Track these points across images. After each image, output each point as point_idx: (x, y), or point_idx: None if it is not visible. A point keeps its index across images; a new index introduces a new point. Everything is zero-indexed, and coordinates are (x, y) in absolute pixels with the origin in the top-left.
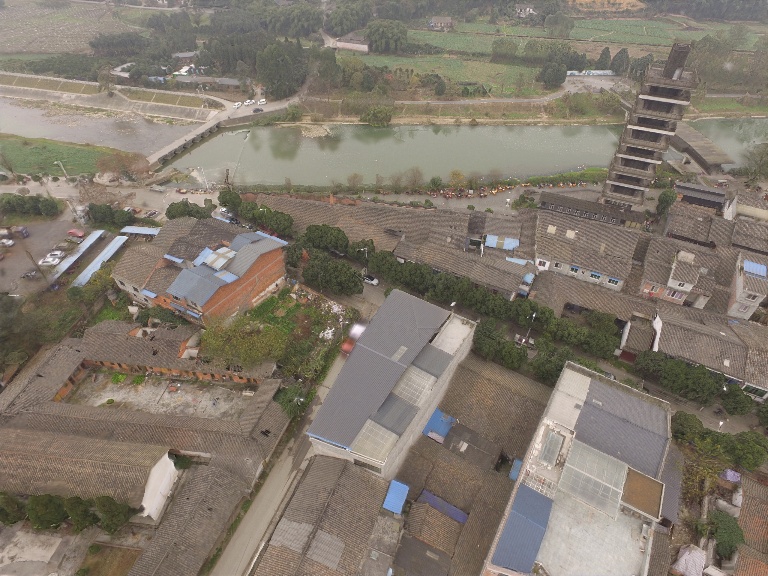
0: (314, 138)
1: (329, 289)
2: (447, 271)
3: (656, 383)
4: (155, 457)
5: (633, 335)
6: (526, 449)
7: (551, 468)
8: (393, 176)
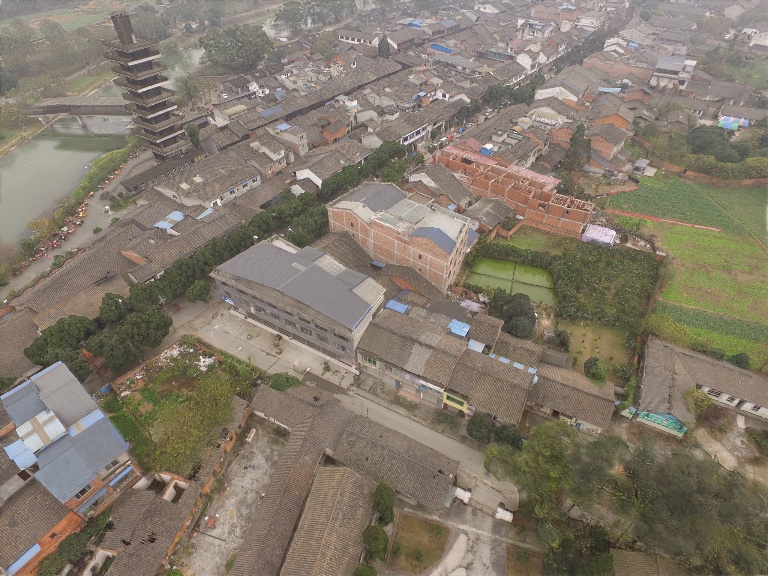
0: None
1: (146, 350)
2: (193, 251)
3: None
4: (332, 472)
5: (304, 188)
6: (368, 255)
7: (402, 223)
8: None
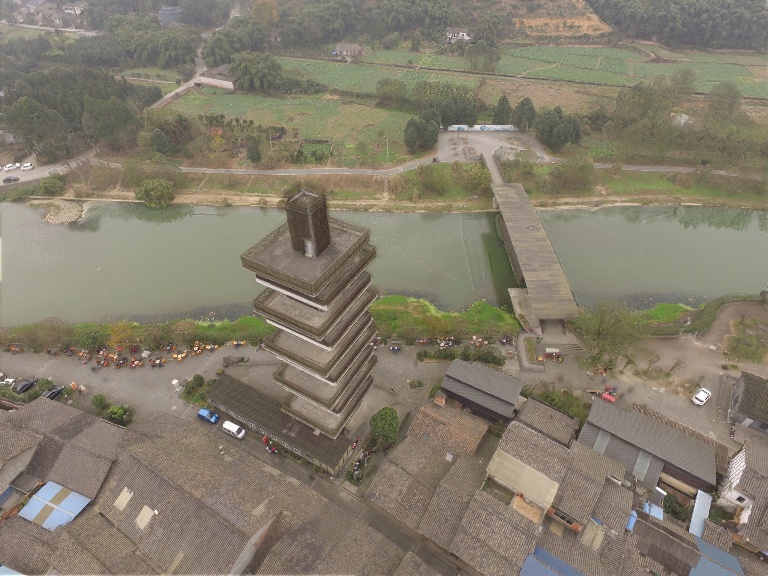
0: (54, 225)
1: None
2: None
3: None
4: None
5: None
6: None
7: None
8: (20, 329)
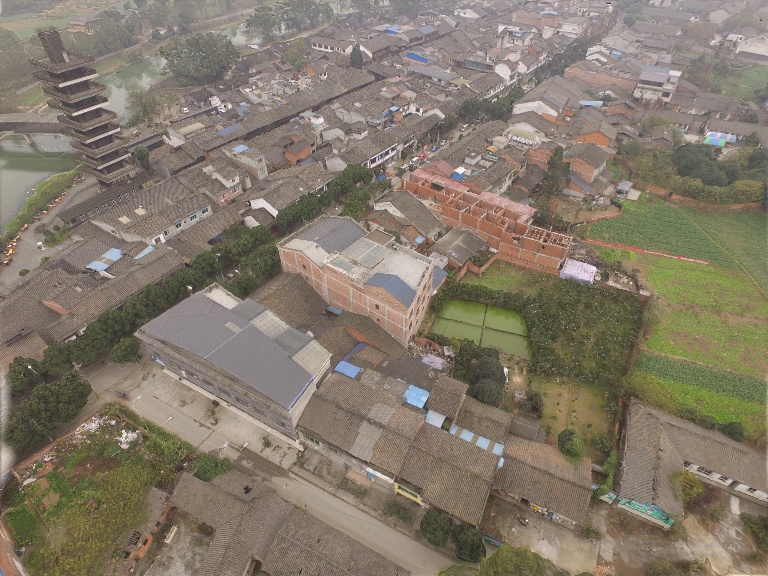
0: None
1: (58, 426)
2: (124, 300)
3: (294, 229)
4: None
5: (258, 219)
6: (323, 300)
7: (357, 268)
8: None
